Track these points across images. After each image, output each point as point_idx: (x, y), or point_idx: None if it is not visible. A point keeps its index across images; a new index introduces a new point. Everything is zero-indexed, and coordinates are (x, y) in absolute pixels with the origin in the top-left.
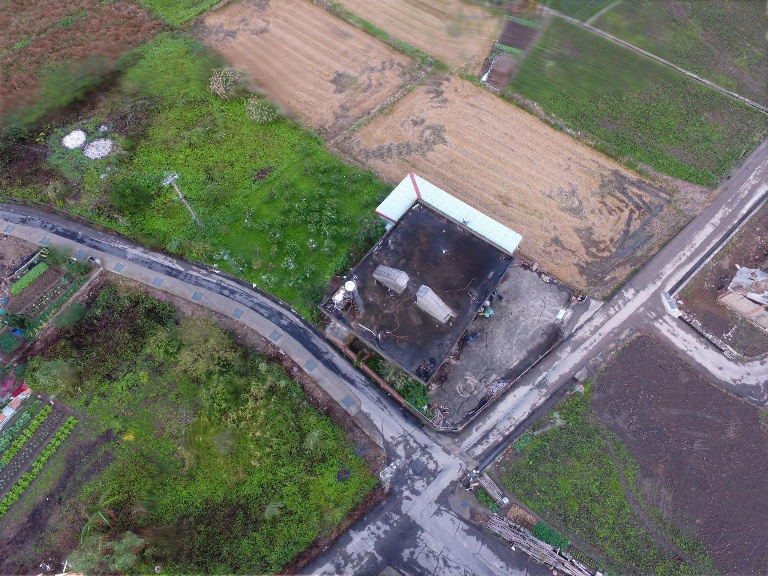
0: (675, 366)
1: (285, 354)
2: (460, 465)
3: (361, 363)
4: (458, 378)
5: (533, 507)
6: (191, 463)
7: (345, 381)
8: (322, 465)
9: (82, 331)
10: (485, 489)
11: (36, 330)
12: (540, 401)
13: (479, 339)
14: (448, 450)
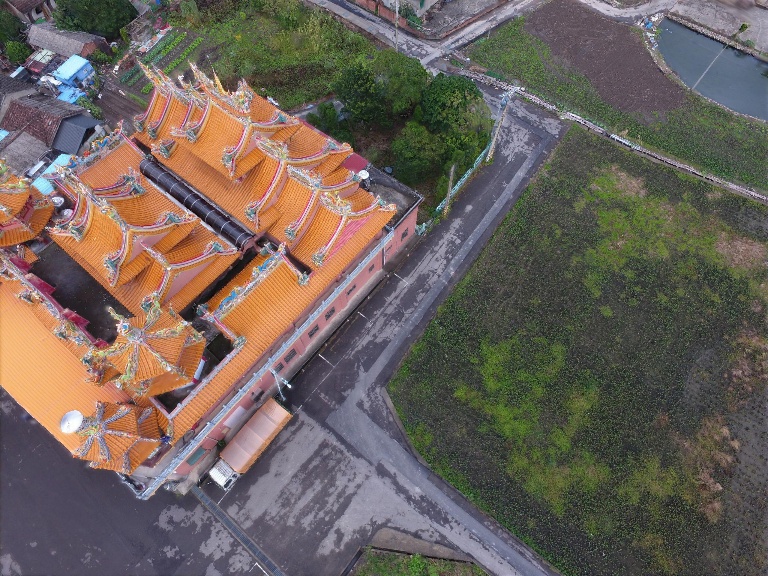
0: (579, 11)
1: (330, 10)
2: (441, 52)
3: (379, 6)
4: (440, 18)
5: (485, 66)
6: (278, 45)
7: (369, 21)
8: (356, 53)
9: (198, 4)
10: (456, 58)
11: (170, 0)
12: (492, 26)
13: (454, 2)
14: (434, 46)
